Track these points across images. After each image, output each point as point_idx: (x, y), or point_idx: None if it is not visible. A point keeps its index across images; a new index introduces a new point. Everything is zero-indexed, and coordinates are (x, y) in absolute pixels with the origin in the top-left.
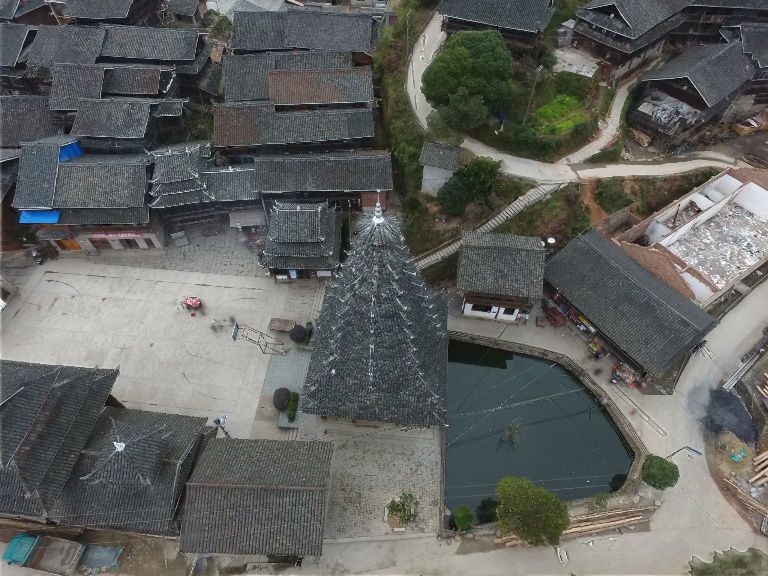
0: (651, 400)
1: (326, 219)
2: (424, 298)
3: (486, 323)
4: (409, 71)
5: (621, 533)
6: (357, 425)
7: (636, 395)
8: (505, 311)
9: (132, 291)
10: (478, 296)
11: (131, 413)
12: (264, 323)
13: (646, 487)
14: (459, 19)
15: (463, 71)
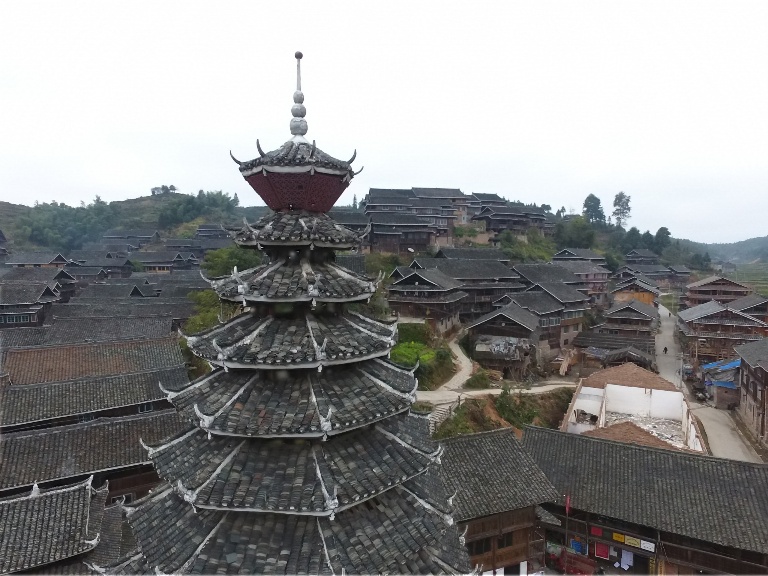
0: None
1: None
2: (423, 421)
3: None
4: None
5: None
6: None
7: None
8: None
9: None
10: None
11: None
12: None
13: None
14: None
15: None
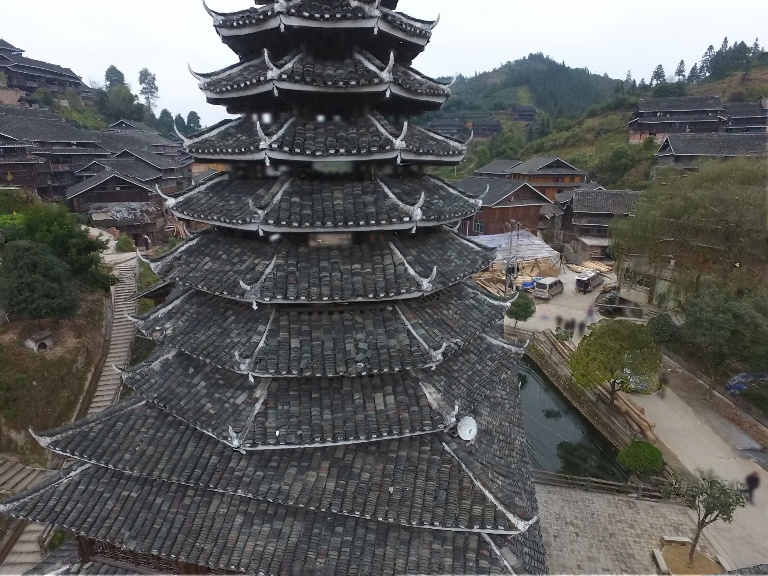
0: None
1: None
2: None
3: None
4: None
5: None
6: None
7: None
8: None
9: None
10: None
11: None
12: None
13: None
14: None
15: None
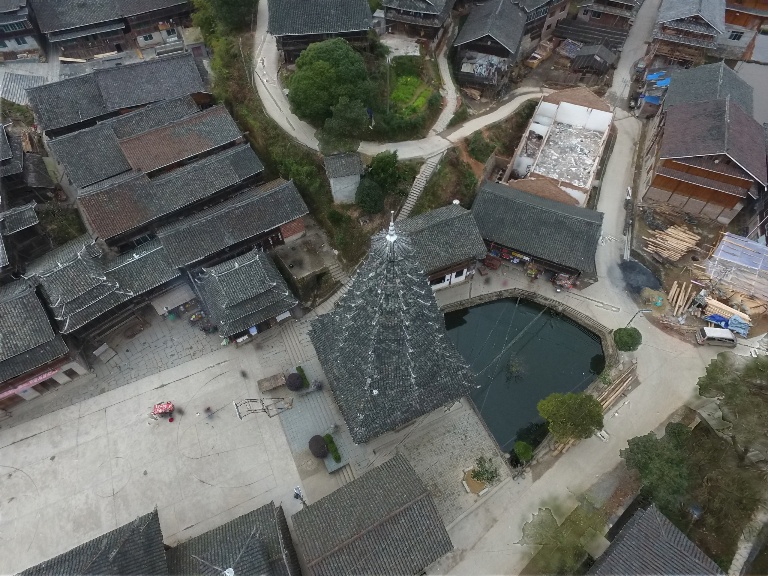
0: (588, 292)
1: (263, 264)
2: (430, 290)
3: (444, 292)
4: (261, 97)
5: (626, 396)
6: (397, 431)
7: (577, 293)
8: (456, 275)
9: (82, 433)
10: None
11: (191, 544)
12: (251, 390)
13: (621, 355)
14: (293, 35)
15: (329, 82)
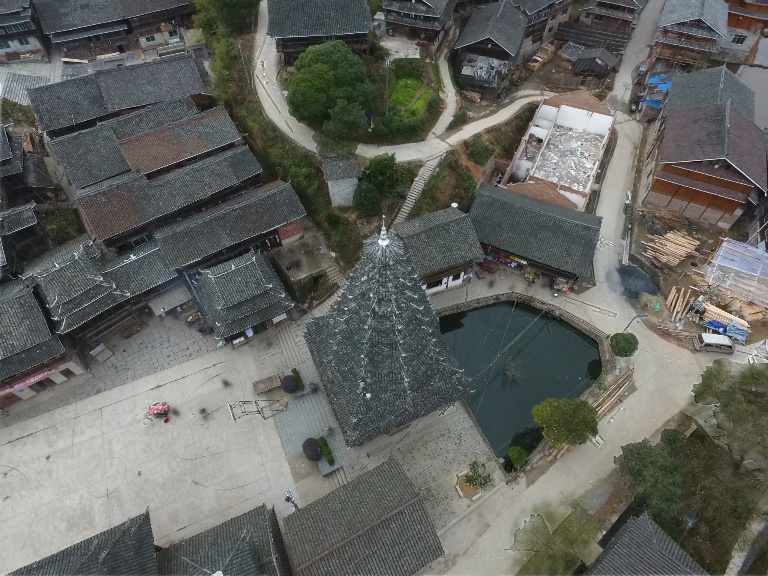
0: (586, 296)
1: (260, 266)
2: (424, 294)
3: (441, 295)
4: (260, 99)
5: (622, 402)
6: (392, 434)
7: (574, 298)
8: (453, 278)
9: (77, 432)
10: (431, 275)
11: (182, 546)
12: (246, 392)
13: (618, 360)
14: (292, 37)
15: (328, 85)
